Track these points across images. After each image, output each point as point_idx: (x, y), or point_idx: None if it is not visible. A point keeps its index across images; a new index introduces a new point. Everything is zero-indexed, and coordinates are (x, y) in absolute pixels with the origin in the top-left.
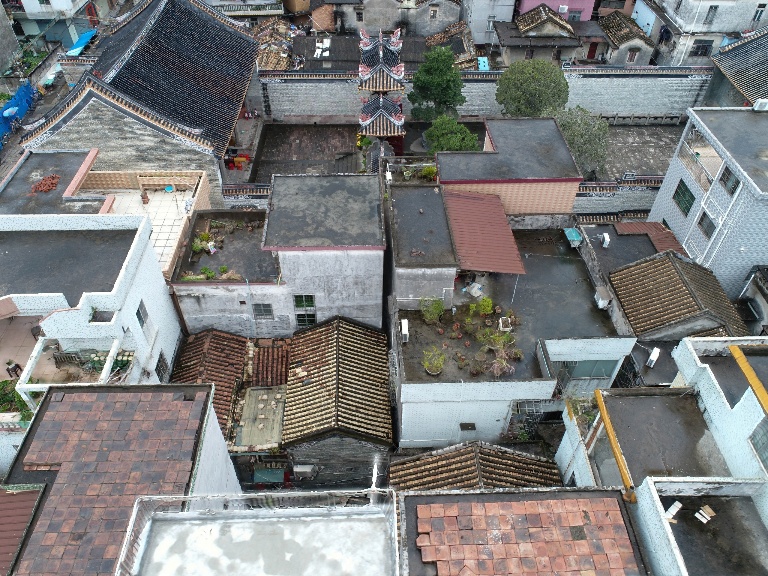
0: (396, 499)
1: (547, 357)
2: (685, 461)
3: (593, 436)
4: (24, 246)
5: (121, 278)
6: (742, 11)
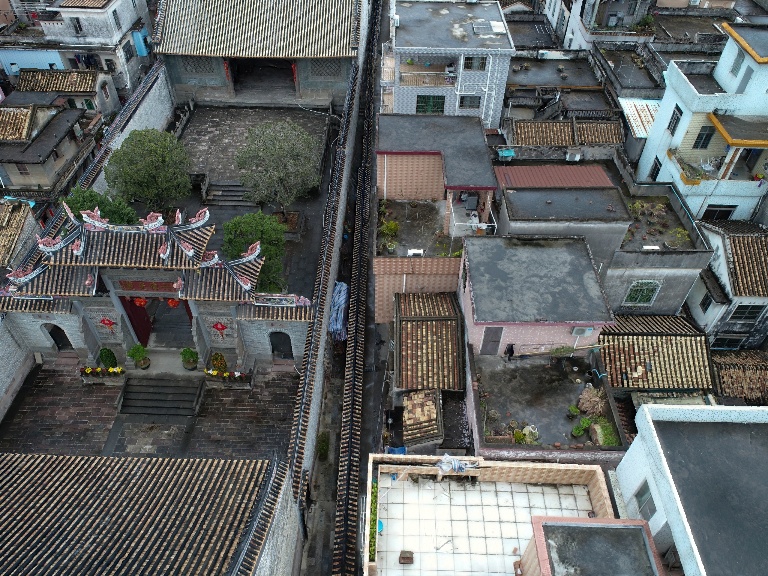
0: (761, 292)
1: (654, 182)
2: (760, 126)
3: (727, 168)
4: (731, 575)
5: (765, 407)
6: (126, 4)
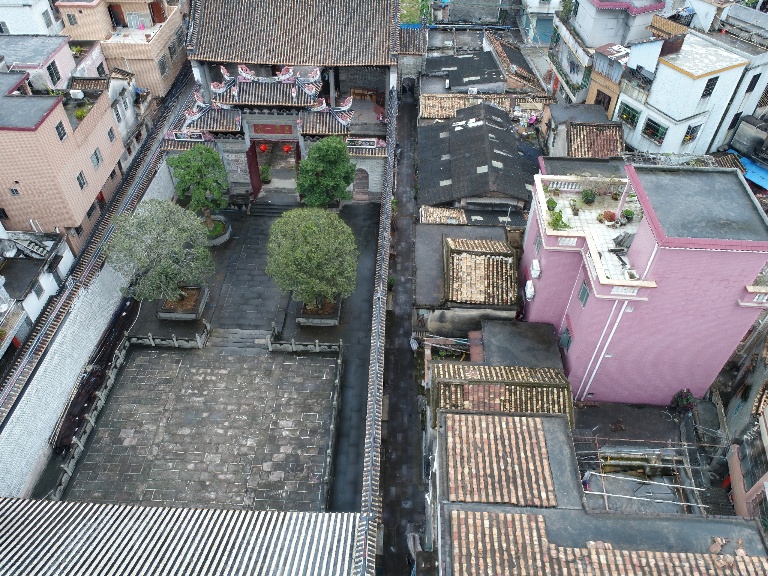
0: None
1: None
2: None
3: None
4: None
5: None
6: None
